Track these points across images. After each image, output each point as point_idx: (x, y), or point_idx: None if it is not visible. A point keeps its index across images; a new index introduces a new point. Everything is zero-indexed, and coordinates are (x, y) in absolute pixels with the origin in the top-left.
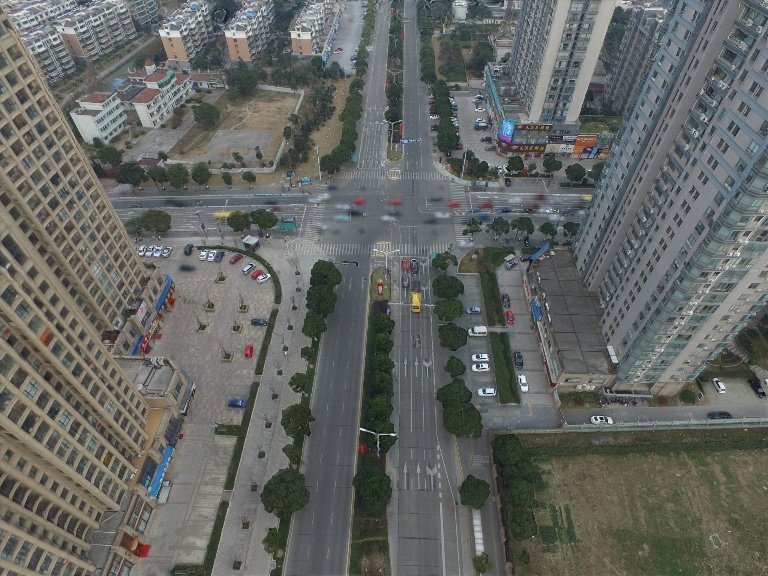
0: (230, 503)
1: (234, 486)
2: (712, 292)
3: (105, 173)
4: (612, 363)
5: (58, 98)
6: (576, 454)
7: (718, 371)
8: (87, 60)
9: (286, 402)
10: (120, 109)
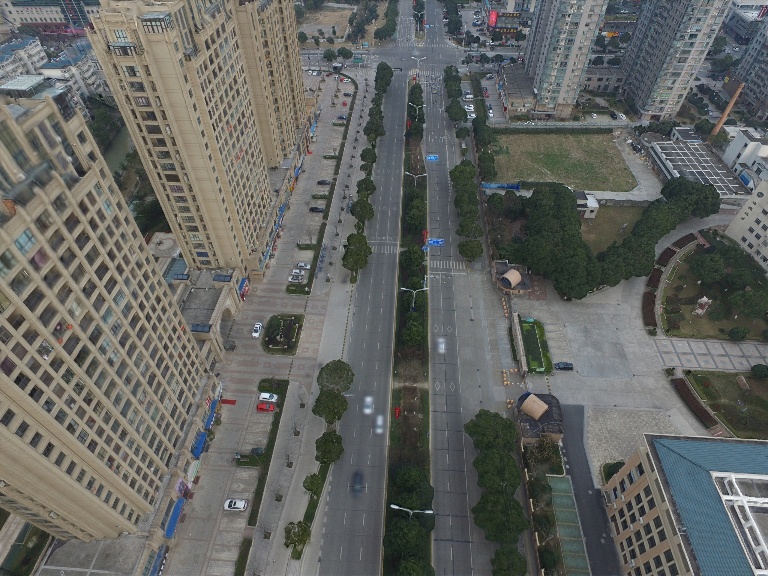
0: (346, 143)
1: (347, 139)
2: (570, 29)
3: None
4: (535, 94)
5: None
6: (514, 133)
7: (595, 111)
8: None
9: (367, 119)
10: None
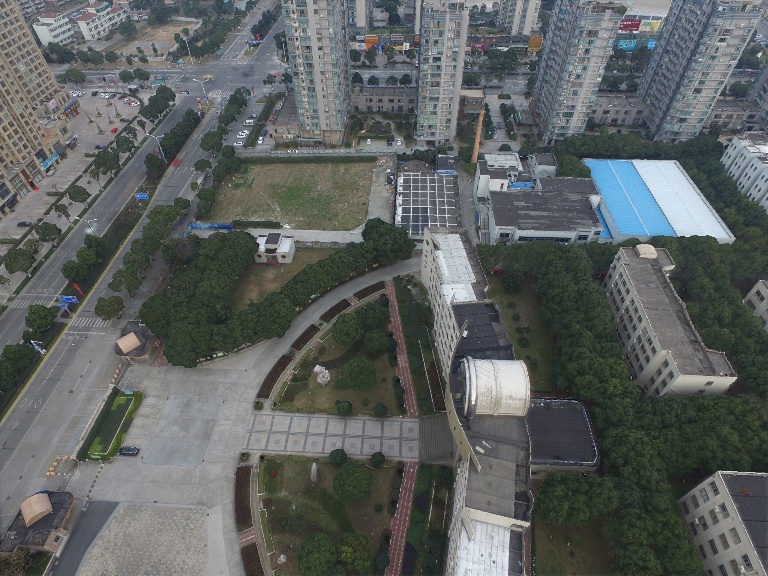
0: (84, 177)
1: None
2: (303, 53)
3: (52, 60)
4: (298, 120)
5: (27, 19)
6: (271, 163)
7: None
8: (55, 4)
9: None
10: (68, 26)
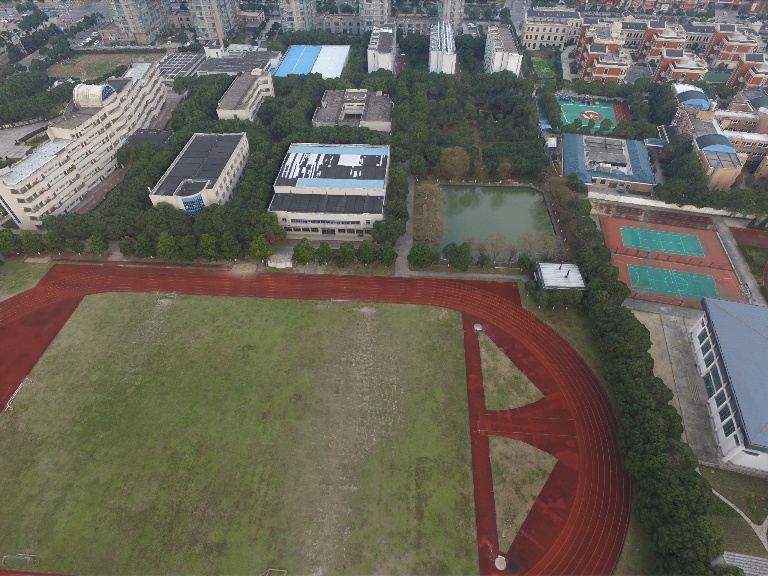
0: None
1: None
2: None
3: None
4: None
5: None
6: (96, 54)
7: None
8: None
9: None
10: None
